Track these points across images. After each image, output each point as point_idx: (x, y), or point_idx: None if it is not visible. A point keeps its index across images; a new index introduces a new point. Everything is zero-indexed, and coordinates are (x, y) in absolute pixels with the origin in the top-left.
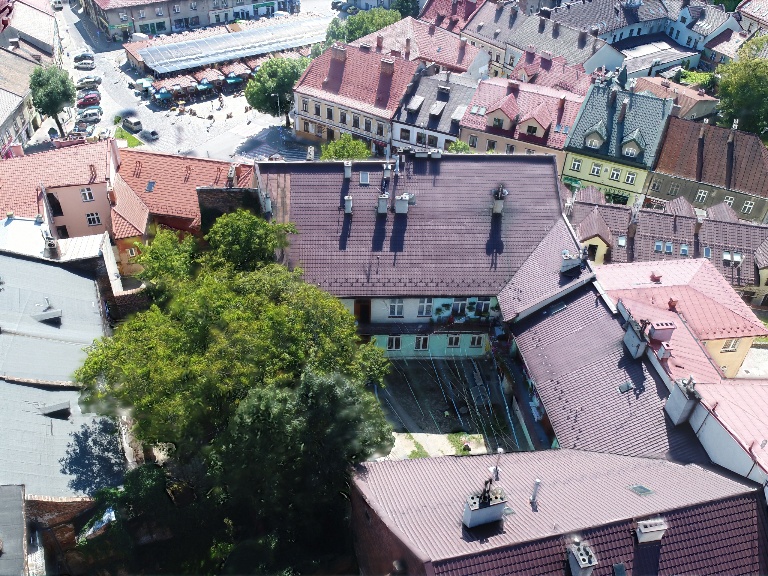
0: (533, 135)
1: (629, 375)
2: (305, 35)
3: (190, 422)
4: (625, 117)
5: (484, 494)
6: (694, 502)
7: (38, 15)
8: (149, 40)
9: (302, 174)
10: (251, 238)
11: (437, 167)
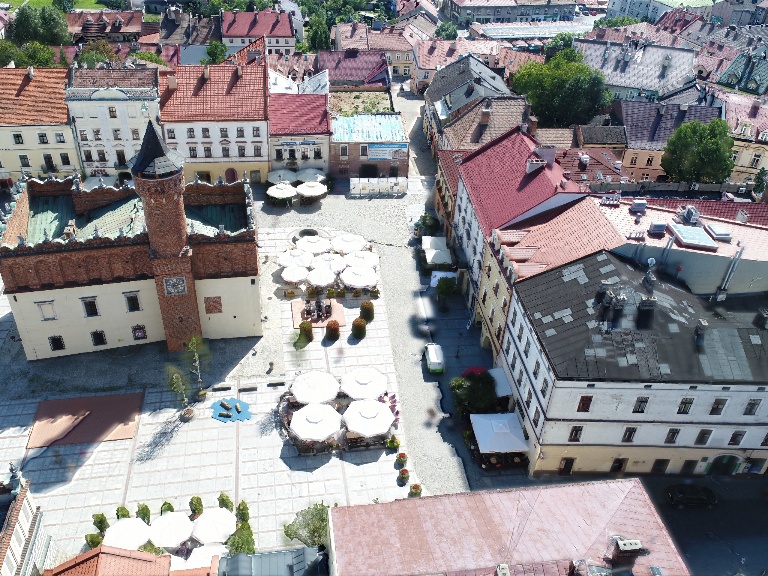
0: (701, 75)
1: (698, 102)
2: (577, 32)
3: (549, 93)
4: (753, 70)
5: (640, 92)
6: None
7: (429, 4)
8: (486, 24)
9: (590, 44)
10: (571, 56)
11: (645, 48)
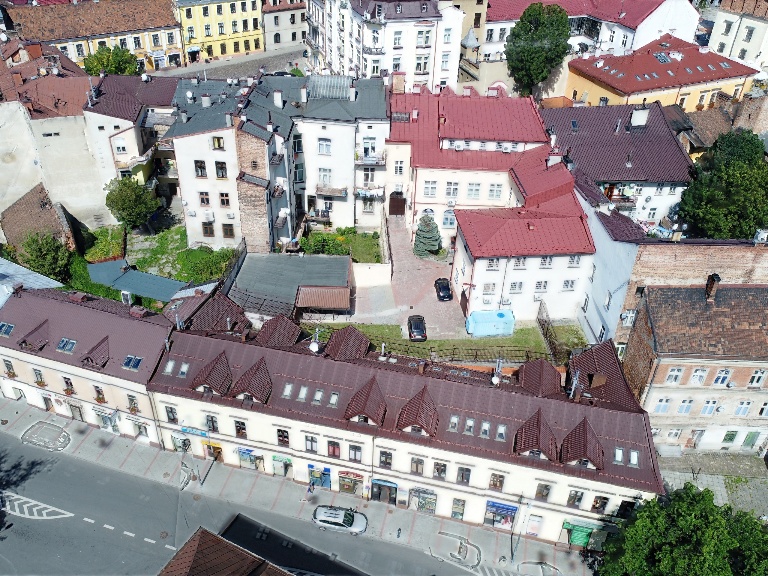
0: None
1: None
2: None
3: None
4: None
5: None
6: (561, 109)
7: None
8: None
9: None
10: None
11: None
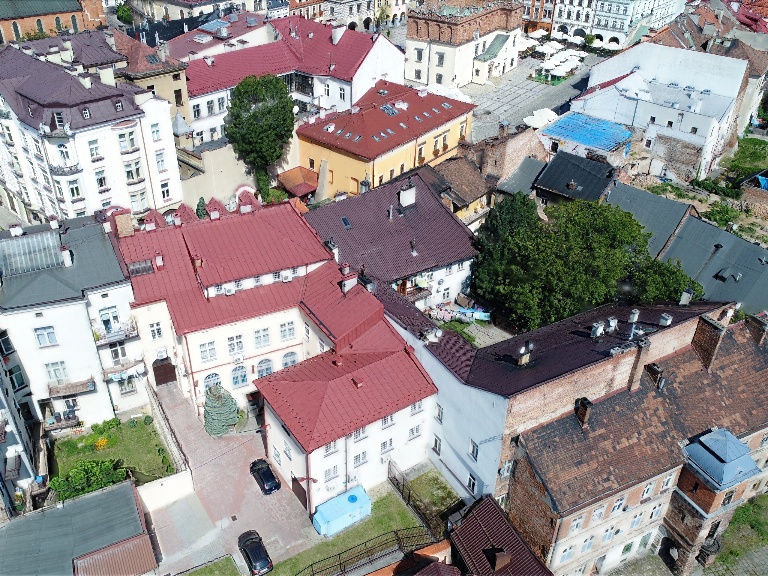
0: None
1: None
2: None
3: None
4: None
5: None
6: (326, 207)
7: None
8: None
9: None
10: None
11: (605, 354)
